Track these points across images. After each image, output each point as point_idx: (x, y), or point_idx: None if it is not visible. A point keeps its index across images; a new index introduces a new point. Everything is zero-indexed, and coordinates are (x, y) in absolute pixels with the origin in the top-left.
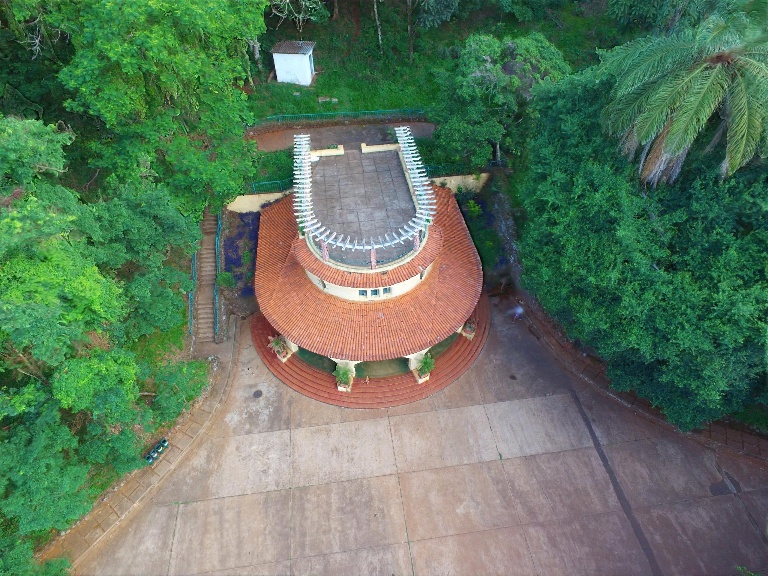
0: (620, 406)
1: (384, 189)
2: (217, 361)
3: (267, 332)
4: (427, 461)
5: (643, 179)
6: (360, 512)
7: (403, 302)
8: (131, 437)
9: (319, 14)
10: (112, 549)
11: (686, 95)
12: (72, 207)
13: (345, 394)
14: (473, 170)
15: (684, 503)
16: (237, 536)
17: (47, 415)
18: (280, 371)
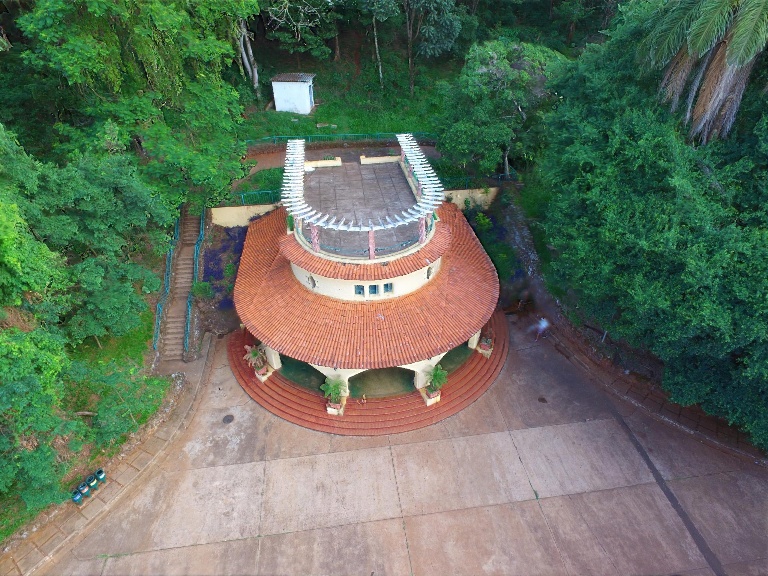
0: (680, 433)
1: (385, 192)
2: (182, 378)
3: None
4: (441, 501)
5: (689, 136)
6: (352, 569)
7: (407, 303)
8: (49, 456)
9: (320, 50)
10: None
11: None
12: None
13: (336, 418)
14: (481, 182)
15: None
16: None
17: None
18: (258, 392)
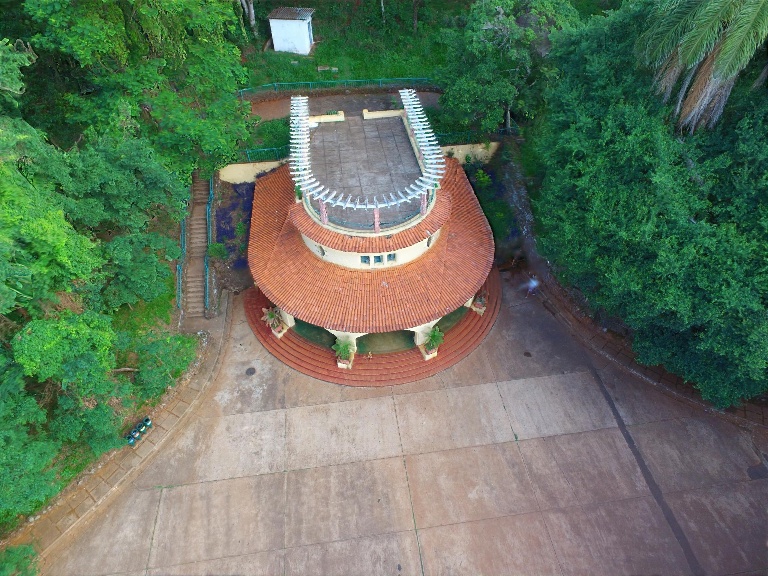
0: (645, 384)
1: (388, 154)
2: (207, 336)
3: (261, 307)
4: (435, 442)
5: (678, 124)
6: (362, 497)
7: (409, 270)
8: (108, 412)
9: None
10: (87, 537)
11: (743, 5)
12: (34, 142)
13: (345, 371)
14: (482, 138)
15: (720, 487)
16: (226, 523)
17: (9, 383)
18: (275, 347)
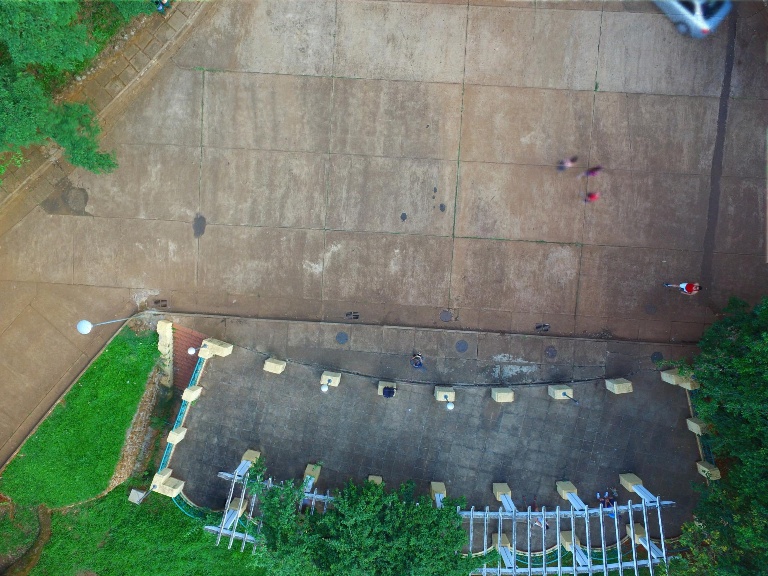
0: None
1: None
2: None
3: None
4: (503, 75)
5: None
6: (411, 119)
7: None
8: None
9: None
10: (138, 106)
11: None
12: None
13: None
14: None
15: None
16: (272, 119)
17: None
18: None
